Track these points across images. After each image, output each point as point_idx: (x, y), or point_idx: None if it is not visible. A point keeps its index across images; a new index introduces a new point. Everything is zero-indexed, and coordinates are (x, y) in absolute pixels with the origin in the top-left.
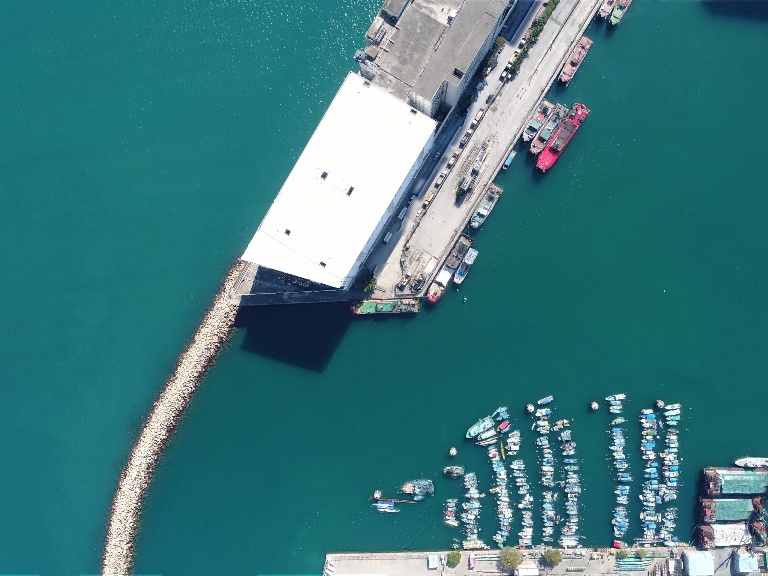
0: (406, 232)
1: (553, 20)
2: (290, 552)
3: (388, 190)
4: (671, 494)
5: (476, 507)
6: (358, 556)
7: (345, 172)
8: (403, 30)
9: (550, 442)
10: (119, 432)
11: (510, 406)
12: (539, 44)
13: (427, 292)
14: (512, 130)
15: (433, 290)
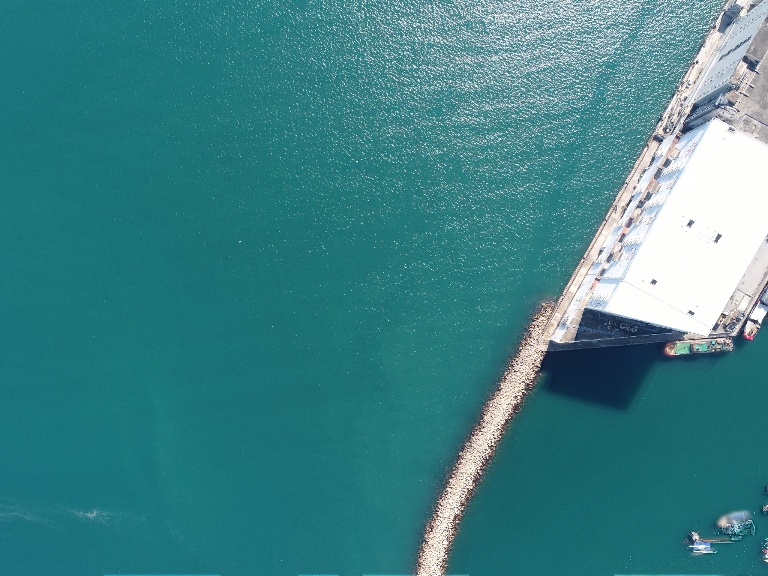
0: None
1: None
2: None
3: (757, 236)
4: None
5: None
6: None
7: (711, 219)
8: (763, 74)
9: None
10: (422, 484)
11: None
12: None
13: (743, 331)
14: None
15: (749, 328)
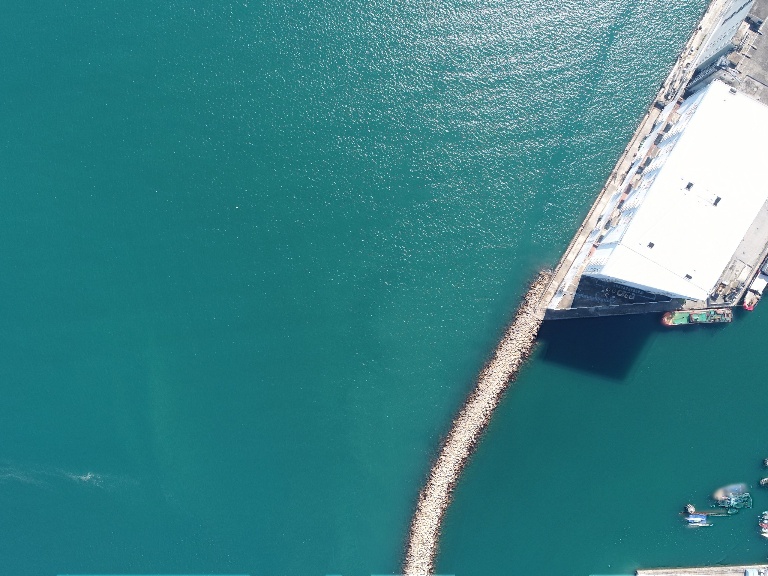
0: None
1: None
2: (597, 570)
3: (757, 199)
4: None
5: None
6: (672, 572)
7: (711, 182)
8: (766, 35)
9: None
10: (416, 452)
11: None
12: None
13: (743, 301)
14: None
15: (749, 299)
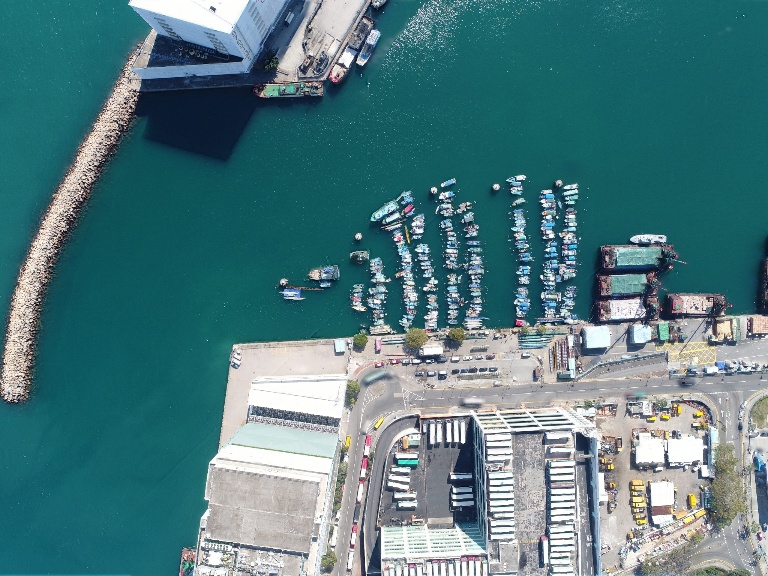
0: (308, 14)
1: None
2: (197, 344)
3: None
4: (570, 273)
5: (382, 291)
6: (265, 344)
7: None
8: None
9: (454, 225)
10: (17, 227)
11: (414, 190)
12: None
13: (330, 73)
14: None
15: (336, 72)
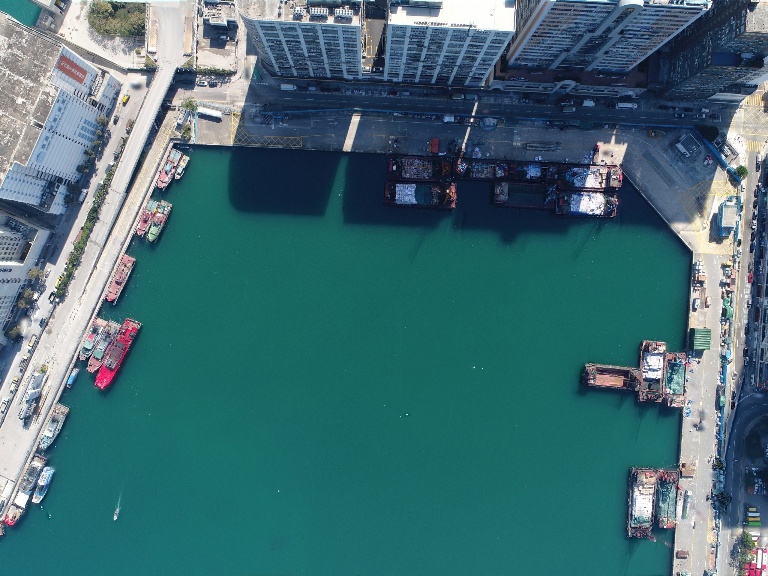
0: None
1: (92, 242)
2: None
3: None
4: None
5: None
6: None
7: None
8: None
9: None
10: None
11: None
12: (83, 266)
13: (6, 516)
14: (70, 350)
15: (12, 513)
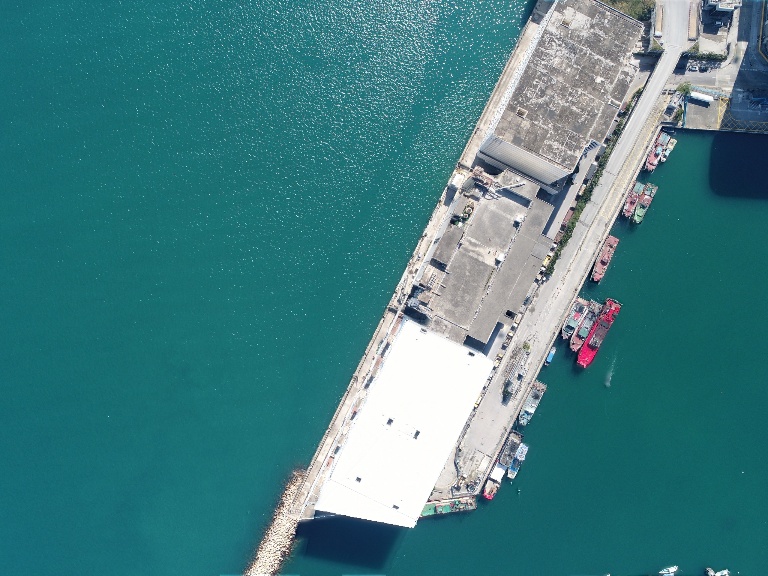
0: None
1: (581, 223)
2: None
3: (453, 431)
4: None
5: None
6: None
7: (410, 417)
8: (453, 274)
9: None
10: None
11: None
12: (569, 246)
13: (483, 490)
14: (551, 328)
15: (489, 488)
